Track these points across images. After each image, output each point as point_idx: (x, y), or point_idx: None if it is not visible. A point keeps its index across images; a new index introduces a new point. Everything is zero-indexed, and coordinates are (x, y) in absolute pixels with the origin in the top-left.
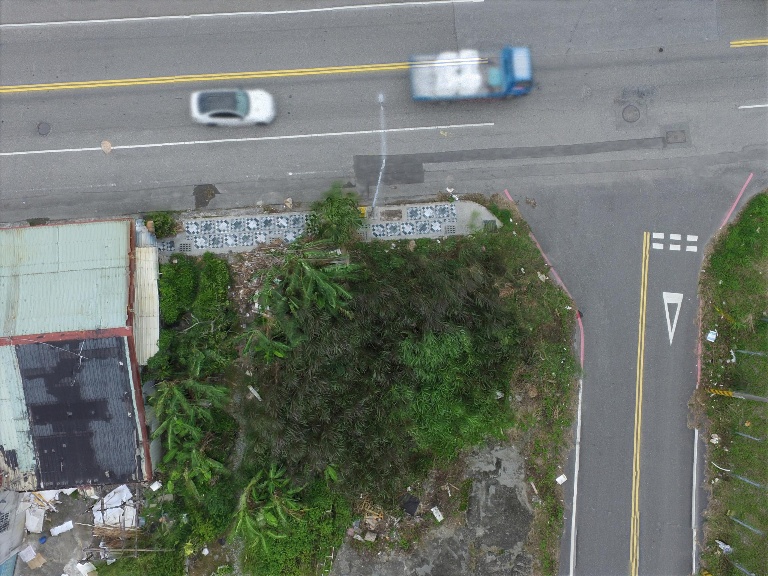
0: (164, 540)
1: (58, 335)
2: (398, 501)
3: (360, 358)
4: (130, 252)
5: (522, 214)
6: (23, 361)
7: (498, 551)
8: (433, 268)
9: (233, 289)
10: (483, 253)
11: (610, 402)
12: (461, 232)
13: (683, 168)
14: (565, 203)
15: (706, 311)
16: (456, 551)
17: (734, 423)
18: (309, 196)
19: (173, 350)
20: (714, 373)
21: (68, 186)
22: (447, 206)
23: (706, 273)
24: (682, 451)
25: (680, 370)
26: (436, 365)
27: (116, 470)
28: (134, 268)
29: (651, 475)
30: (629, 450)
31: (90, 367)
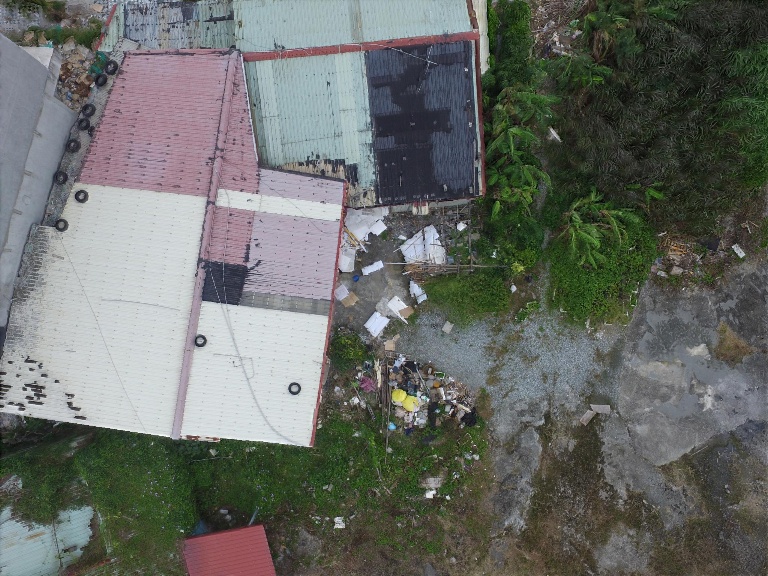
0: (479, 272)
1: (407, 40)
2: (699, 239)
3: None
4: None
5: None
6: (370, 69)
7: None
8: None
9: None
10: None
11: None
12: None
13: None
14: None
15: None
16: (759, 286)
17: None
18: None
19: None
20: None
21: None
22: None
23: None
24: None
25: None
26: (767, 73)
27: (453, 184)
28: None
29: None
30: None
31: (436, 73)
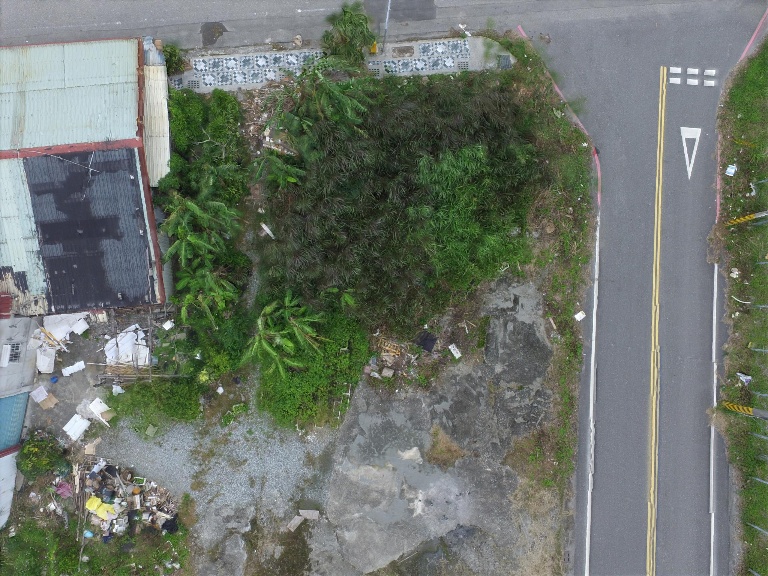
0: None
1: (67, 147)
2: (415, 339)
3: (375, 181)
4: (138, 67)
5: (536, 50)
6: (31, 175)
7: (517, 387)
8: (448, 93)
9: (243, 126)
10: (498, 86)
11: (628, 238)
12: (475, 68)
13: (699, 2)
14: (580, 38)
15: (724, 146)
16: (474, 388)
17: (754, 255)
18: (319, 34)
19: (184, 179)
20: (733, 207)
21: (72, 24)
22: (460, 42)
23: (724, 107)
24: (702, 286)
25: (699, 205)
26: (453, 181)
27: (128, 292)
28: (143, 84)
29: (671, 310)
30: (648, 285)
31: (100, 181)
